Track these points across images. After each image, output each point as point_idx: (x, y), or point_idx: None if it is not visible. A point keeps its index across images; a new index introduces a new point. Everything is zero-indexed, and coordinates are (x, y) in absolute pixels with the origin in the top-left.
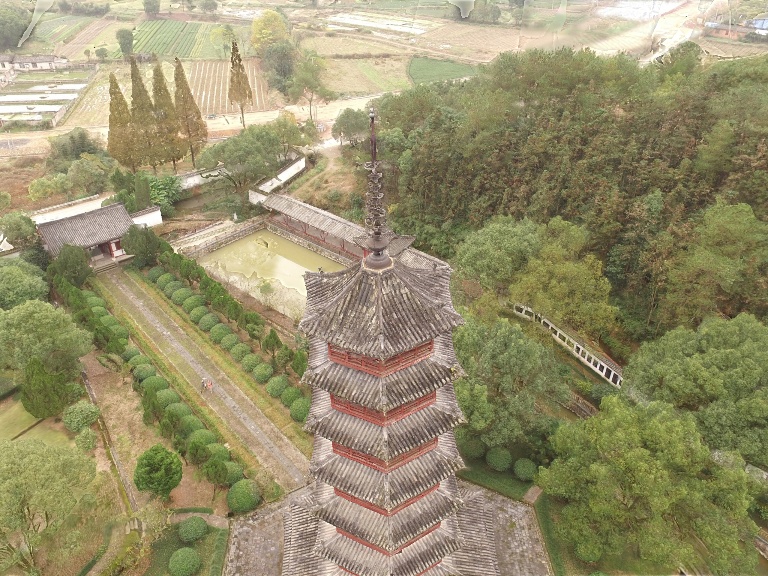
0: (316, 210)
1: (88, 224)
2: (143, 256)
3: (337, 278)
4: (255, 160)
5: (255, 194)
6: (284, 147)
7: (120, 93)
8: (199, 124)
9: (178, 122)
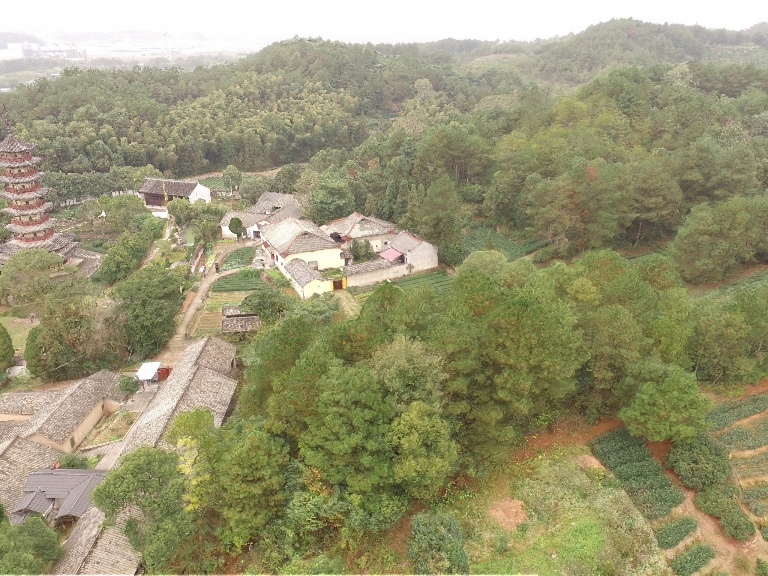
0: None
1: None
2: None
3: (8, 146)
4: None
5: None
6: None
7: None
8: None
9: None
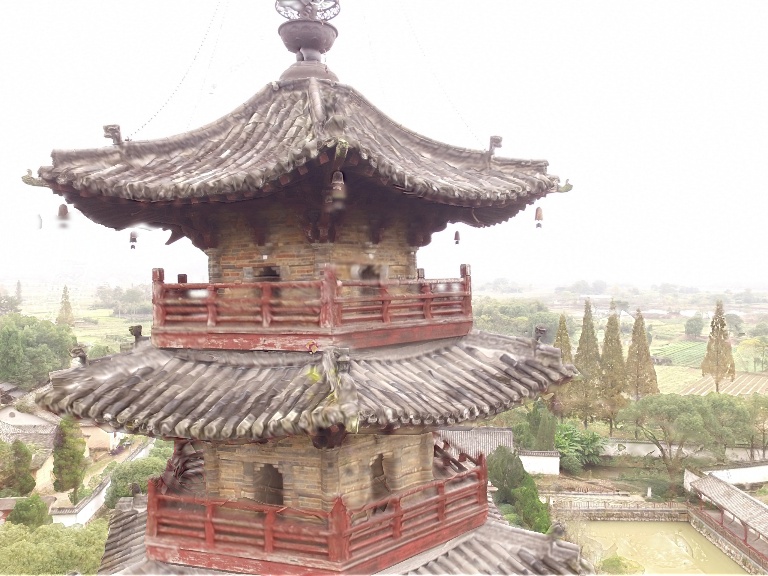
0: (767, 508)
1: (468, 438)
2: (498, 484)
3: None
4: (689, 419)
5: (691, 476)
6: (763, 436)
7: (567, 335)
8: (650, 386)
9: (625, 379)
